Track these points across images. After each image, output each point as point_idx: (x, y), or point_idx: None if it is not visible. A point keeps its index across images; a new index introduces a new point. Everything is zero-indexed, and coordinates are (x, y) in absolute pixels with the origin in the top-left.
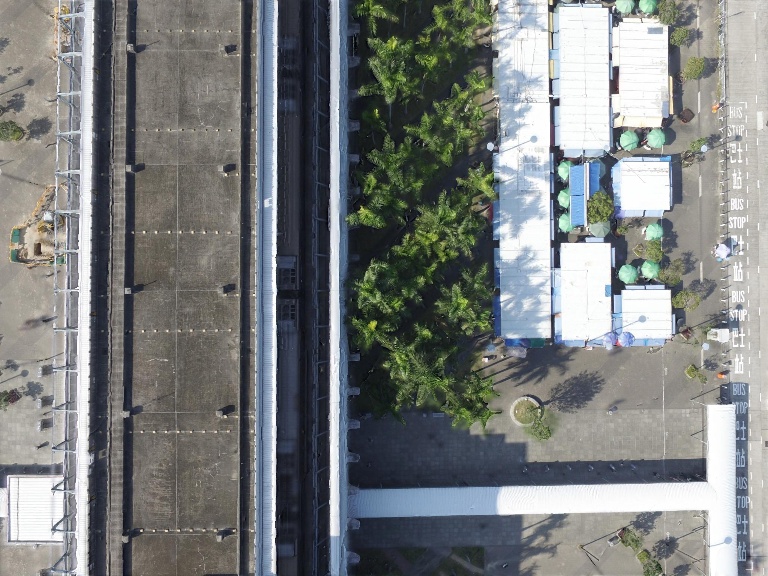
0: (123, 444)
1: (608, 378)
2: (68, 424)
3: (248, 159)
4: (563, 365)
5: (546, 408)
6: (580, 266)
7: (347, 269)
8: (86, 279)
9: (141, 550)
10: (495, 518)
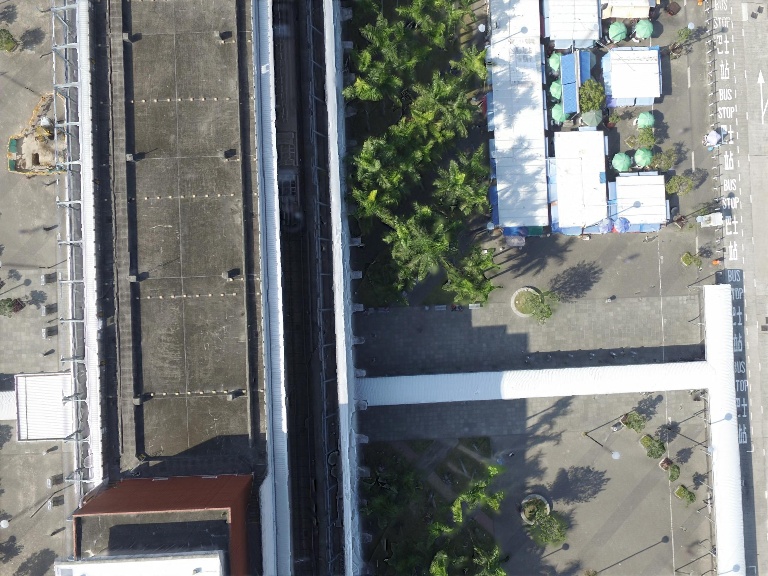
0: (131, 309)
1: (606, 268)
2: (74, 303)
3: (244, 26)
4: (561, 256)
5: (546, 299)
6: (574, 154)
7: (345, 151)
8: (87, 150)
9: (152, 414)
10: (500, 408)
